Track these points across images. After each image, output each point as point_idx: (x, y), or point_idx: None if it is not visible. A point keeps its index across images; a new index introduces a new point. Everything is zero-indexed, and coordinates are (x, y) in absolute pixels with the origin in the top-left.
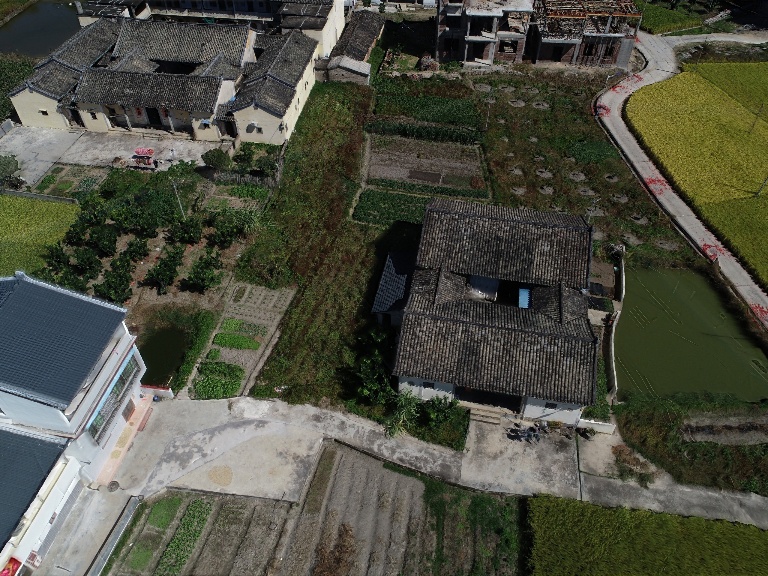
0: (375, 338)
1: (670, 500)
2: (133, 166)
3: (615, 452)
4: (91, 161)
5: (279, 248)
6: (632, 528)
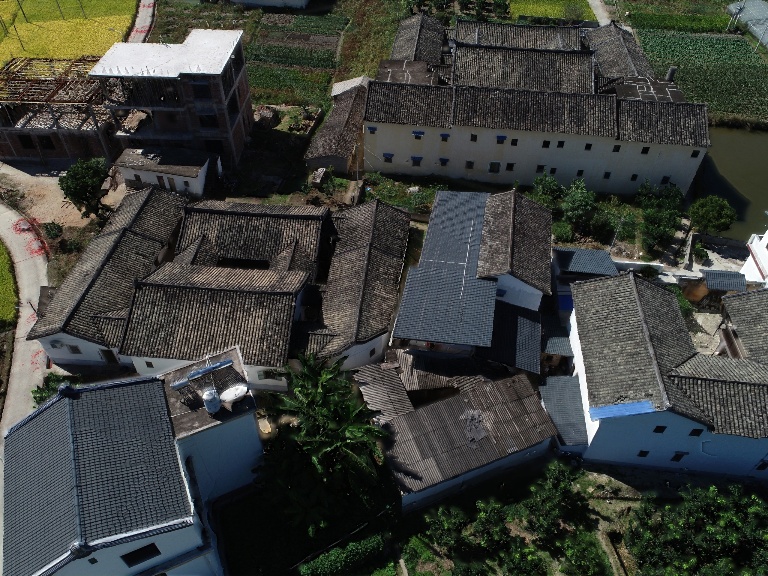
0: None
1: None
2: None
3: None
4: None
5: (389, 5)
6: None
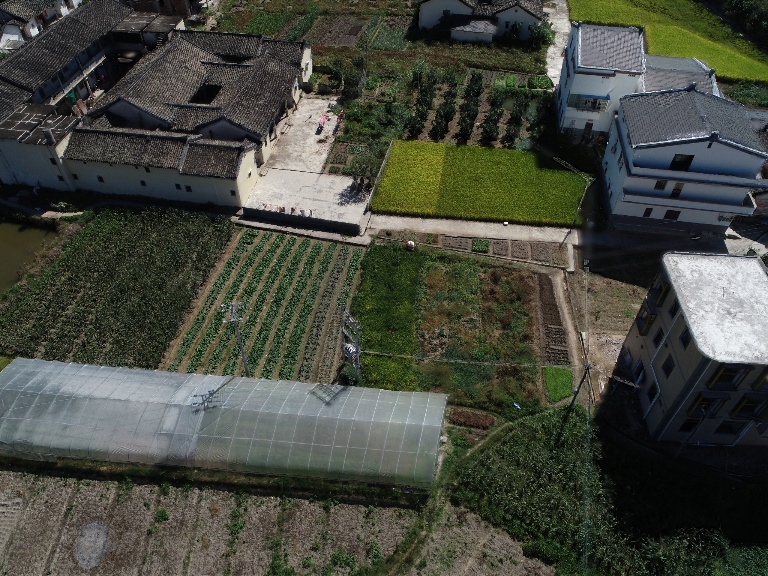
0: (519, 26)
1: (561, 2)
2: (333, 132)
3: (545, 7)
4: (322, 154)
5: None
6: (577, 6)
